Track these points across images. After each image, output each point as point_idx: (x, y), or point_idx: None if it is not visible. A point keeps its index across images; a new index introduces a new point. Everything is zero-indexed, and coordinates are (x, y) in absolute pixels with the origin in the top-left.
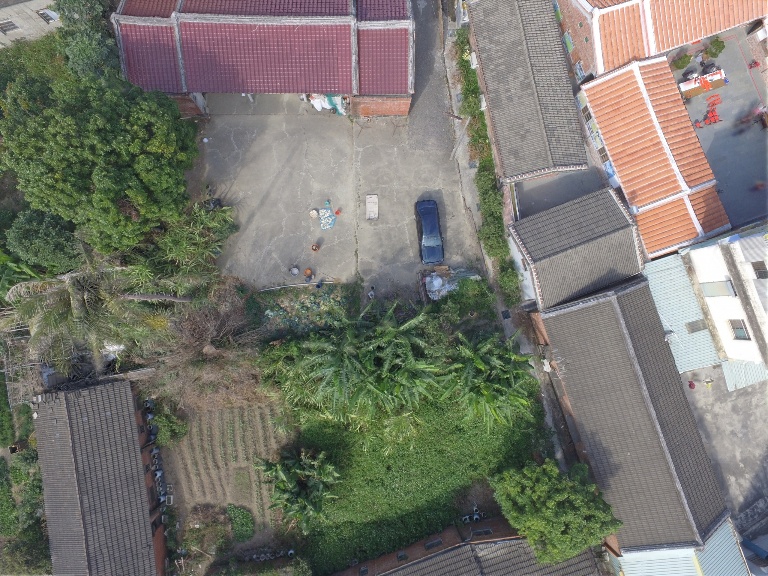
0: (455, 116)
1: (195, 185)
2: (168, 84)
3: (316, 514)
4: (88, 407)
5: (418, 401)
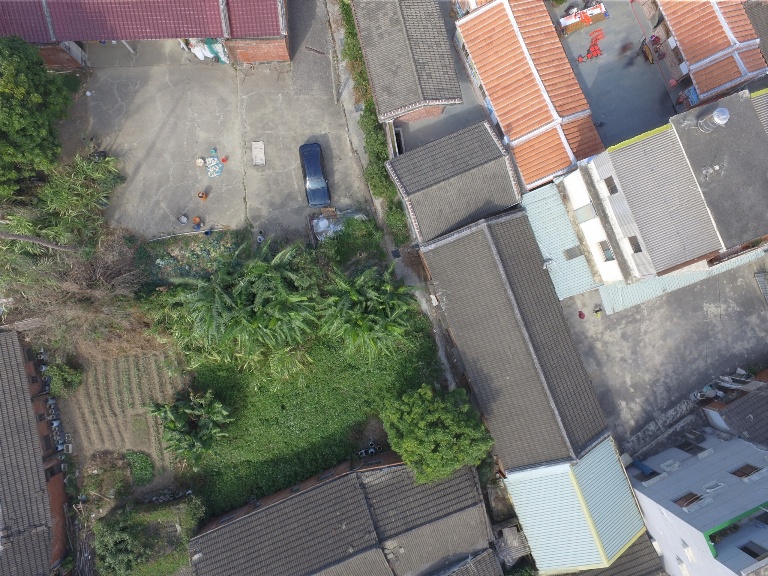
0: (317, 51)
1: (80, 138)
2: (37, 34)
3: (204, 451)
4: None
5: (299, 336)
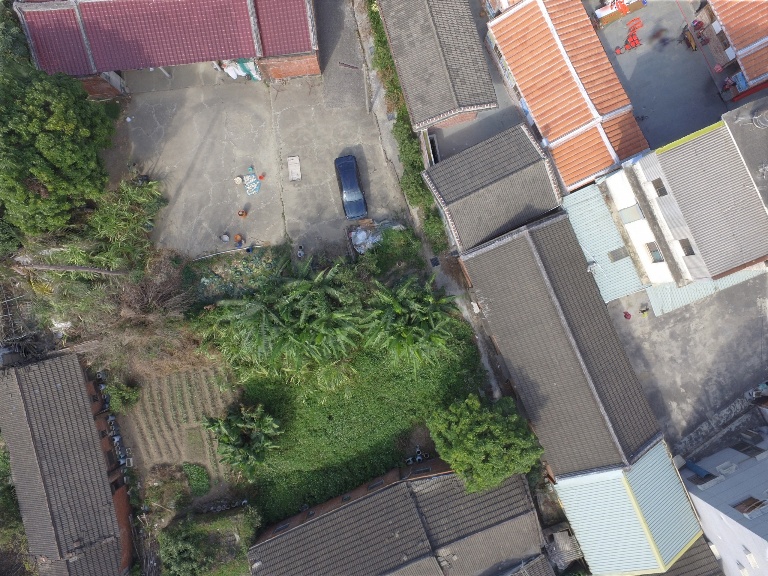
0: (350, 66)
1: (123, 164)
2: (79, 67)
3: (258, 463)
4: (39, 380)
5: (344, 350)
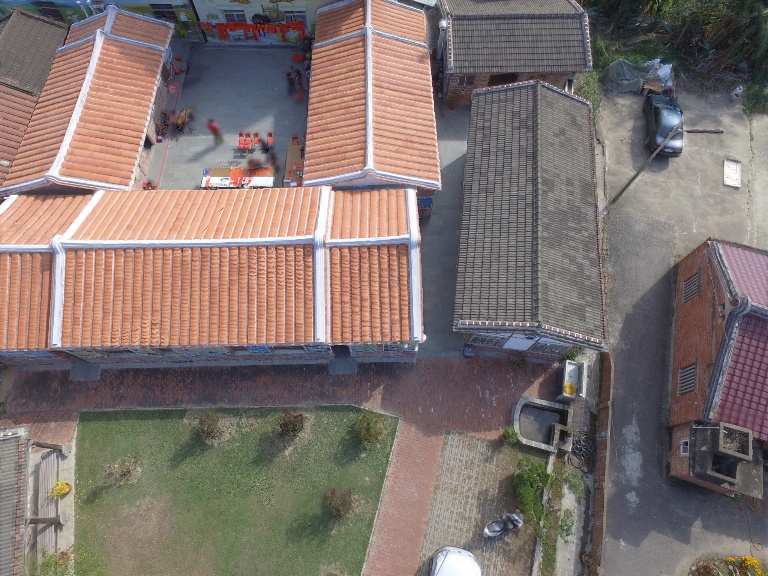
0: None
1: None
2: None
3: None
4: None
5: None
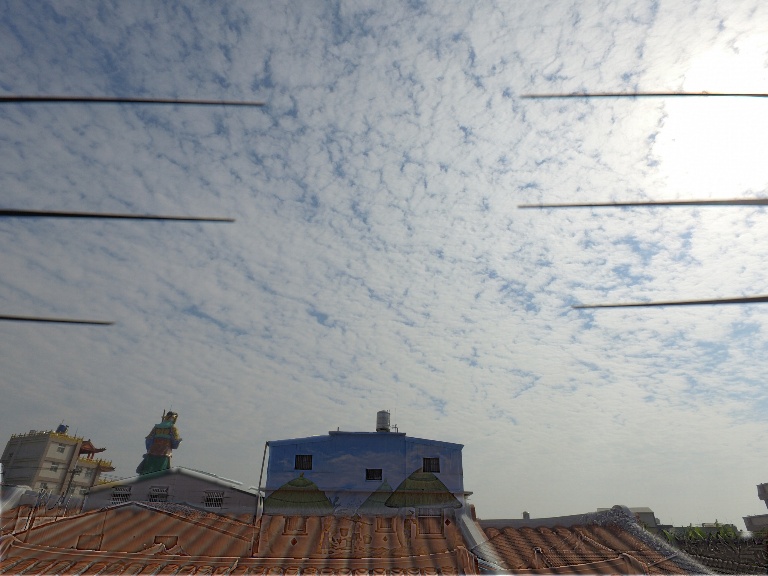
0: None
1: None
2: None
3: None
4: None
5: None
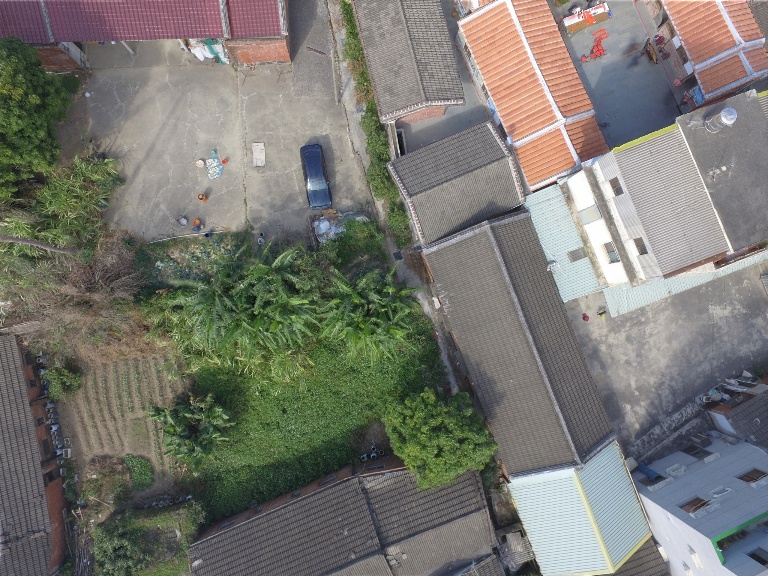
0: None
1: (79, 140)
2: (36, 35)
3: (204, 455)
4: None
5: (300, 339)
